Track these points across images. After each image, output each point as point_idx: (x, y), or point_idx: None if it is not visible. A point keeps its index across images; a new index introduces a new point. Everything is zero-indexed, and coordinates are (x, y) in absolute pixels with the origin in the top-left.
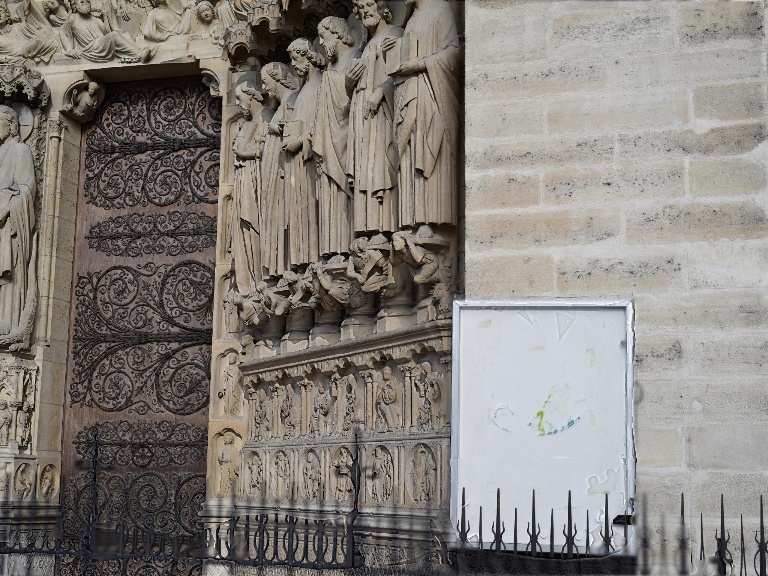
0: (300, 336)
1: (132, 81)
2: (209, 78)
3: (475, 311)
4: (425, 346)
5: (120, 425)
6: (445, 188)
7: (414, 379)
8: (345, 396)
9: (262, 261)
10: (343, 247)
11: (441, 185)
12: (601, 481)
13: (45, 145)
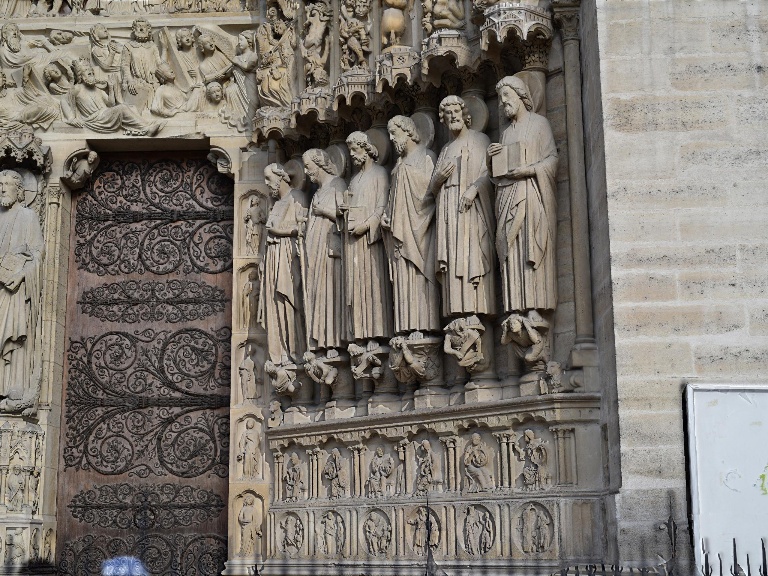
0: (348, 403)
1: (126, 152)
2: (215, 155)
3: (704, 393)
4: (532, 416)
5: (120, 488)
6: (550, 278)
7: (512, 445)
8: (414, 459)
9: (308, 333)
10: (423, 325)
11: (546, 276)
12: None
13: (45, 211)
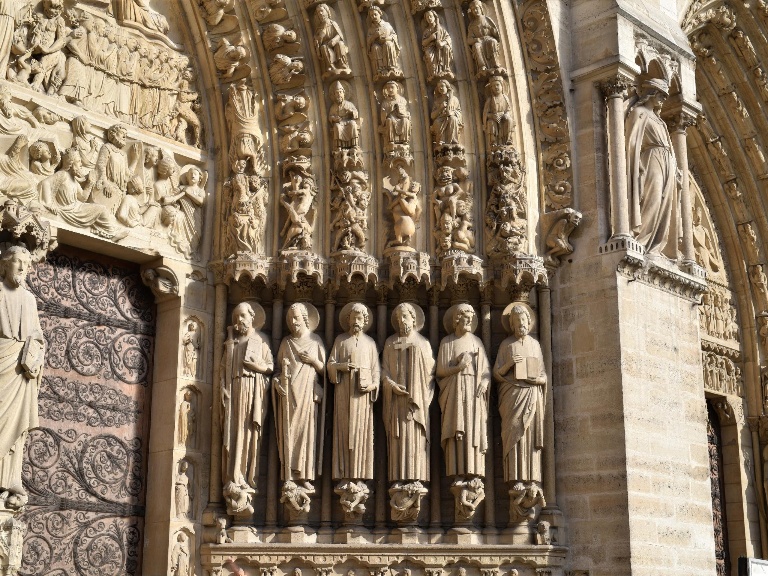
0: None
1: (63, 244)
2: (156, 272)
3: None
4: (524, 559)
5: None
6: None
7: None
8: None
9: (290, 465)
10: (424, 477)
11: (539, 457)
12: None
13: None
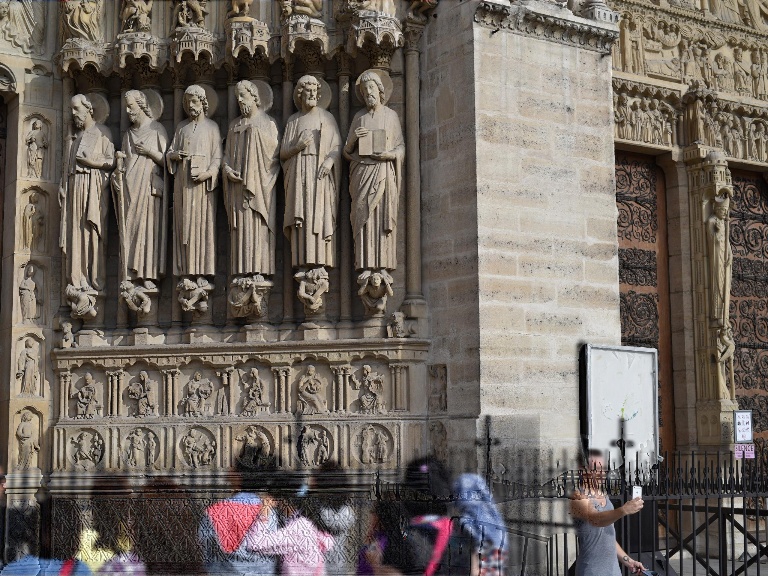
0: (159, 331)
1: None
2: None
3: (596, 350)
4: (374, 354)
5: None
6: None
7: (349, 376)
8: (238, 385)
9: (126, 263)
10: (266, 269)
11: (394, 242)
12: (645, 446)
13: None
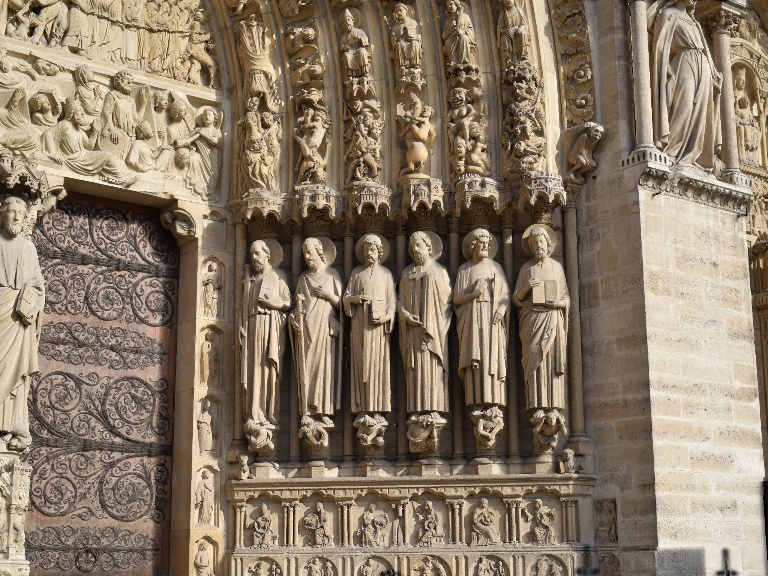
0: (334, 464)
1: (77, 193)
2: (173, 215)
3: None
4: (547, 489)
5: (63, 530)
6: None
7: (521, 509)
8: (412, 516)
9: None
10: (442, 407)
11: (563, 384)
12: None
13: None
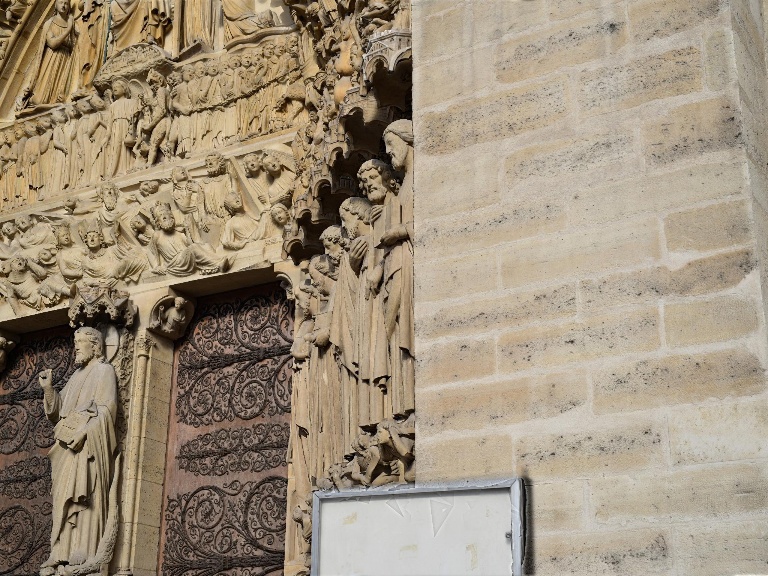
0: None
1: (220, 293)
2: (286, 282)
3: (338, 503)
4: None
5: None
6: None
7: None
8: None
9: None
10: None
11: None
12: None
13: (132, 364)
